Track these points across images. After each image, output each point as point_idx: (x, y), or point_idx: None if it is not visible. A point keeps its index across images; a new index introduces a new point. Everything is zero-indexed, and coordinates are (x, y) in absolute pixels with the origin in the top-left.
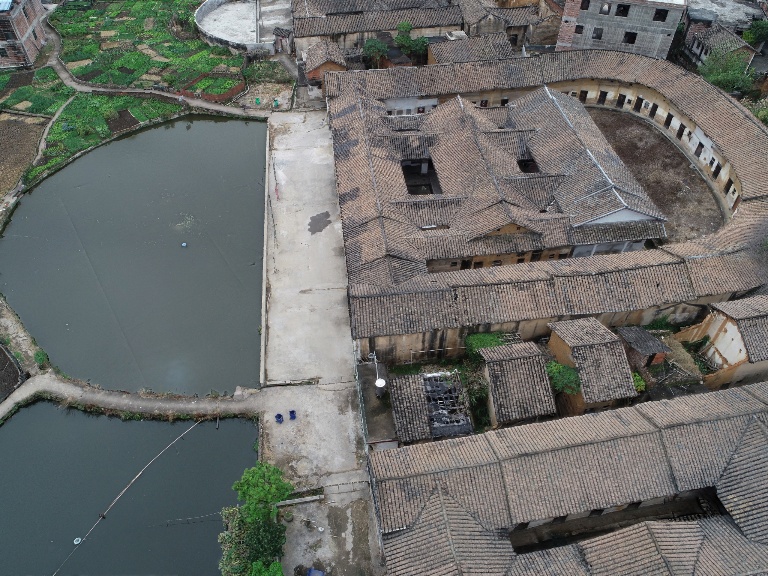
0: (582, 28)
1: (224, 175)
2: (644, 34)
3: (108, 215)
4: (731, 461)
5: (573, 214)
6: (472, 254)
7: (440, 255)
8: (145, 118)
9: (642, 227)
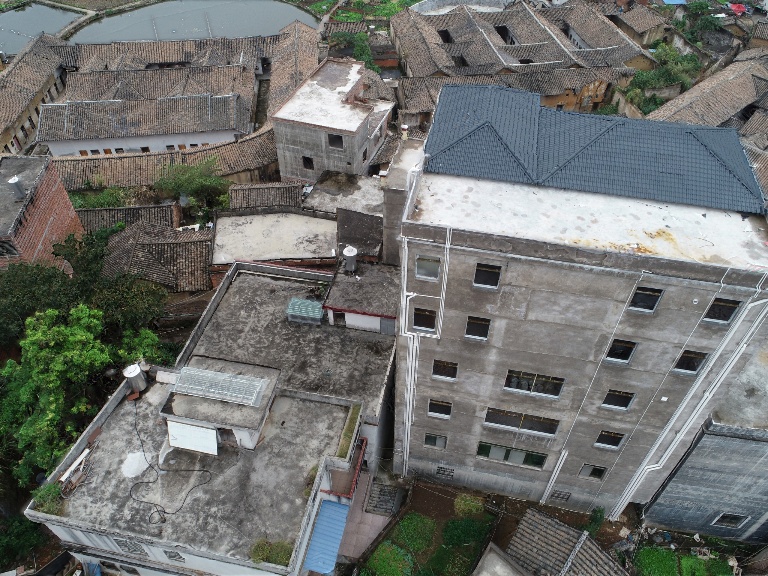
0: None
1: (241, 36)
2: None
3: (213, 13)
4: None
5: None
6: None
7: None
8: (312, 6)
9: None
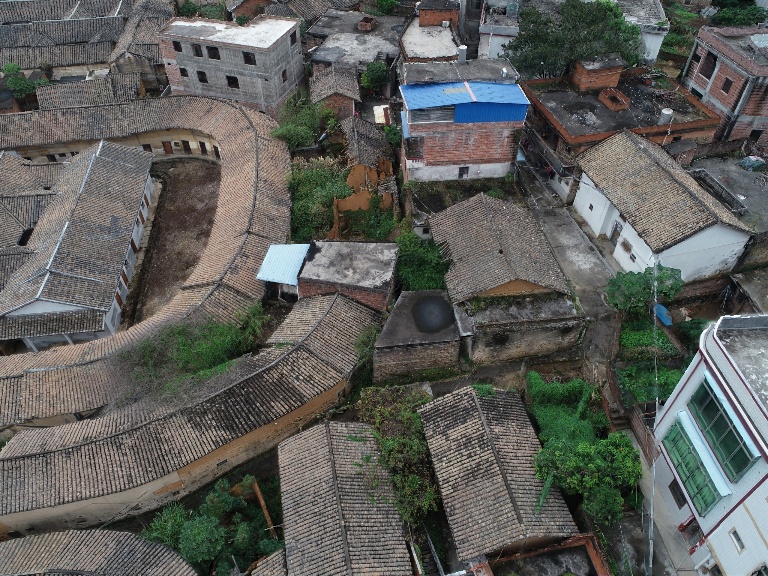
0: (187, 71)
1: None
2: (243, 78)
3: None
4: None
5: (0, 303)
6: None
7: None
8: None
9: (78, 318)
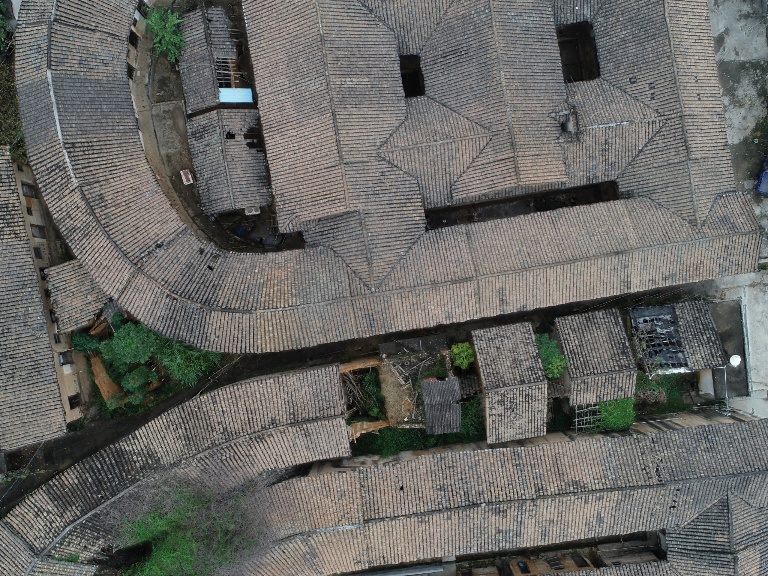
0: None
1: None
2: None
3: None
4: (408, 250)
5: None
6: (605, 570)
7: (648, 568)
8: None
9: None
